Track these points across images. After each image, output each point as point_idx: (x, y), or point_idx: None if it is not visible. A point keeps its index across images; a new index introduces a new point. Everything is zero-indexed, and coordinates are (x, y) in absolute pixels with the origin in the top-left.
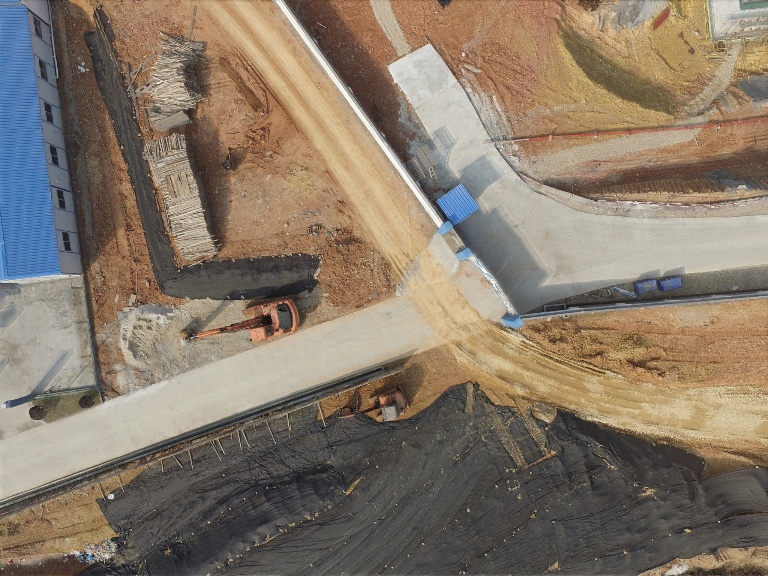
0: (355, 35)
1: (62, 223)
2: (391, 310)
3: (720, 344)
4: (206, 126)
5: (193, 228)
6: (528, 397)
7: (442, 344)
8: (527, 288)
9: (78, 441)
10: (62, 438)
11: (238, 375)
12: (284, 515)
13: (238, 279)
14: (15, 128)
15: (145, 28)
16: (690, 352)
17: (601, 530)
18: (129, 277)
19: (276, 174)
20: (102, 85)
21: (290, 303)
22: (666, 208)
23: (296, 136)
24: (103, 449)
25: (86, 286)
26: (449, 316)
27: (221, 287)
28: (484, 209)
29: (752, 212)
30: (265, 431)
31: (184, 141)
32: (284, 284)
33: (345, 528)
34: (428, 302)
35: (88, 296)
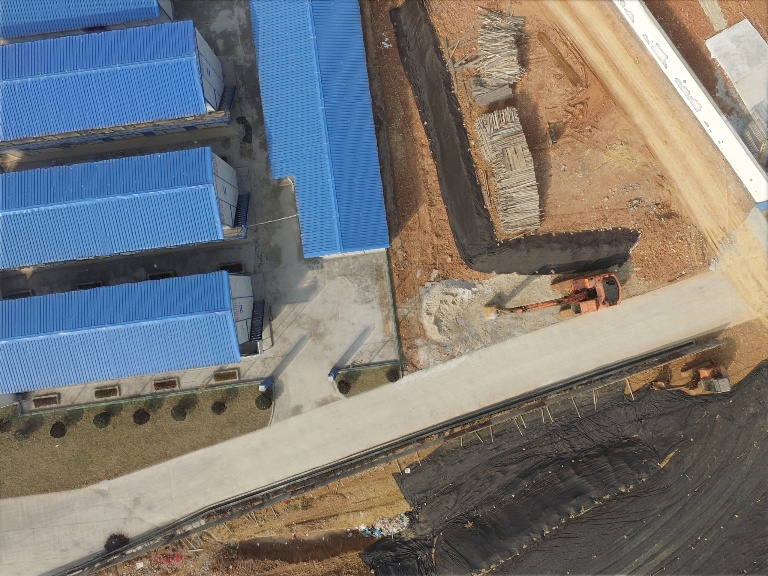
0: (673, 10)
1: None
2: (704, 284)
3: None
4: (525, 101)
5: (525, 201)
6: None
7: (755, 318)
8: None
9: (376, 415)
10: (360, 412)
11: (542, 349)
12: (599, 487)
13: (556, 253)
14: (347, 101)
15: (463, 3)
16: None
17: None
18: (430, 252)
19: (595, 148)
20: (405, 61)
21: None
22: None
23: (614, 111)
24: (401, 423)
25: (388, 261)
26: (763, 290)
27: (534, 261)
28: None
29: None
30: (569, 405)
31: (517, 114)
32: (599, 258)
33: (659, 500)
34: (742, 276)
35: (390, 271)
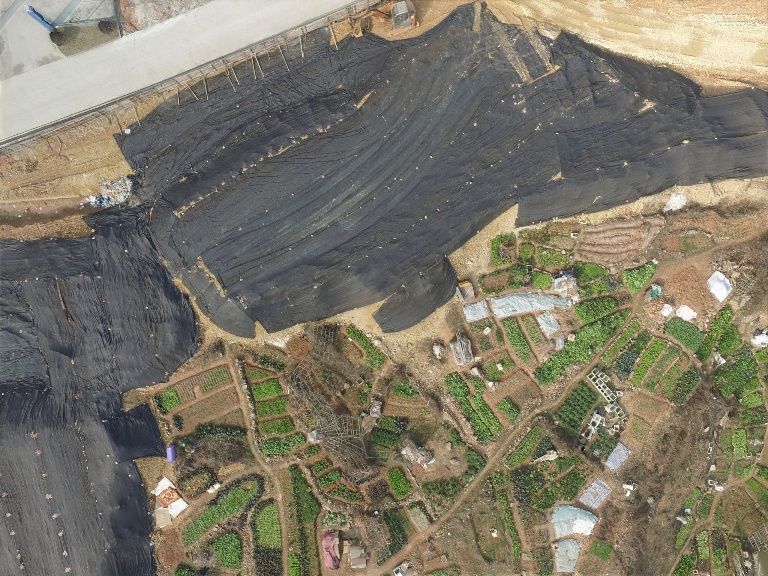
0: None
1: None
2: None
3: None
4: None
5: None
6: (534, 18)
7: None
8: None
9: (96, 75)
10: (81, 72)
11: (253, 5)
12: (297, 127)
13: None
14: None
15: None
16: None
17: (603, 141)
18: None
19: None
20: None
21: None
22: None
23: None
24: (121, 83)
25: None
26: None
27: None
28: None
29: None
30: (279, 60)
31: None
32: None
33: (356, 141)
34: None
35: None
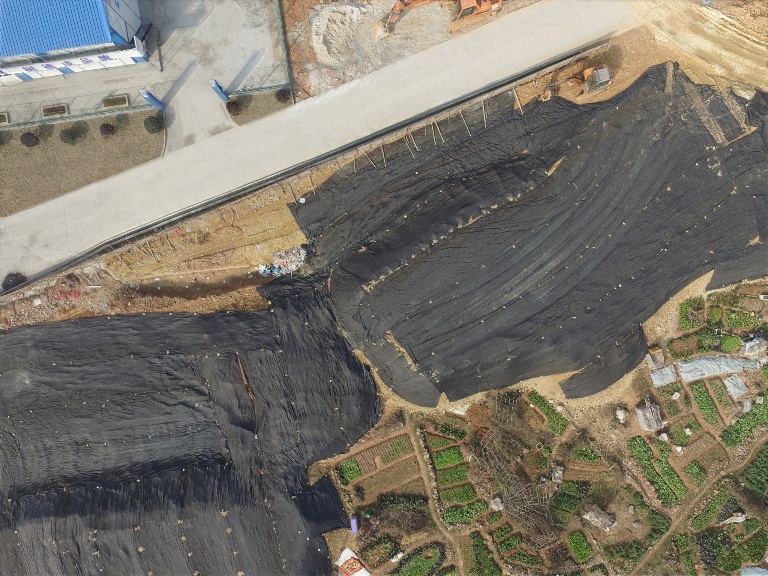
0: None
1: None
2: None
3: None
4: None
5: None
6: (726, 77)
7: (641, 25)
8: None
9: (269, 144)
10: (253, 141)
11: (432, 69)
12: (487, 197)
13: None
14: None
15: None
16: None
17: None
18: None
19: None
20: None
21: None
22: None
23: None
24: (294, 151)
25: None
26: None
27: None
28: None
29: None
30: (460, 125)
31: None
32: None
33: (547, 209)
34: None
35: None
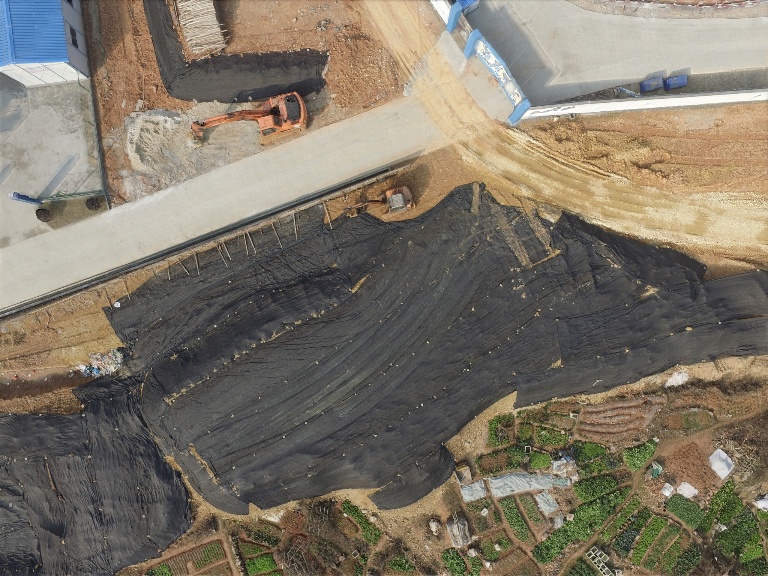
0: None
1: (69, 18)
2: (398, 110)
3: (724, 147)
4: None
5: (202, 15)
6: (533, 199)
7: (449, 144)
8: (534, 87)
9: (84, 248)
10: (68, 245)
11: (245, 180)
12: (290, 312)
13: (246, 75)
14: None
15: None
16: (694, 155)
17: (604, 328)
18: (136, 82)
19: None
20: None
21: (298, 95)
22: (673, 7)
23: None
24: (109, 256)
25: (93, 91)
26: (456, 116)
27: (229, 86)
28: (492, 6)
29: (758, 14)
30: (272, 236)
31: None
32: (292, 82)
33: (351, 326)
34: (435, 102)
35: (95, 101)
